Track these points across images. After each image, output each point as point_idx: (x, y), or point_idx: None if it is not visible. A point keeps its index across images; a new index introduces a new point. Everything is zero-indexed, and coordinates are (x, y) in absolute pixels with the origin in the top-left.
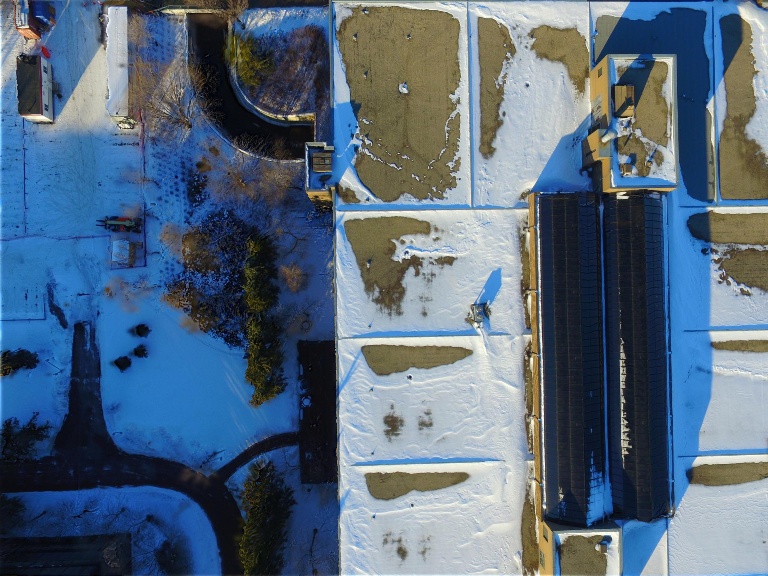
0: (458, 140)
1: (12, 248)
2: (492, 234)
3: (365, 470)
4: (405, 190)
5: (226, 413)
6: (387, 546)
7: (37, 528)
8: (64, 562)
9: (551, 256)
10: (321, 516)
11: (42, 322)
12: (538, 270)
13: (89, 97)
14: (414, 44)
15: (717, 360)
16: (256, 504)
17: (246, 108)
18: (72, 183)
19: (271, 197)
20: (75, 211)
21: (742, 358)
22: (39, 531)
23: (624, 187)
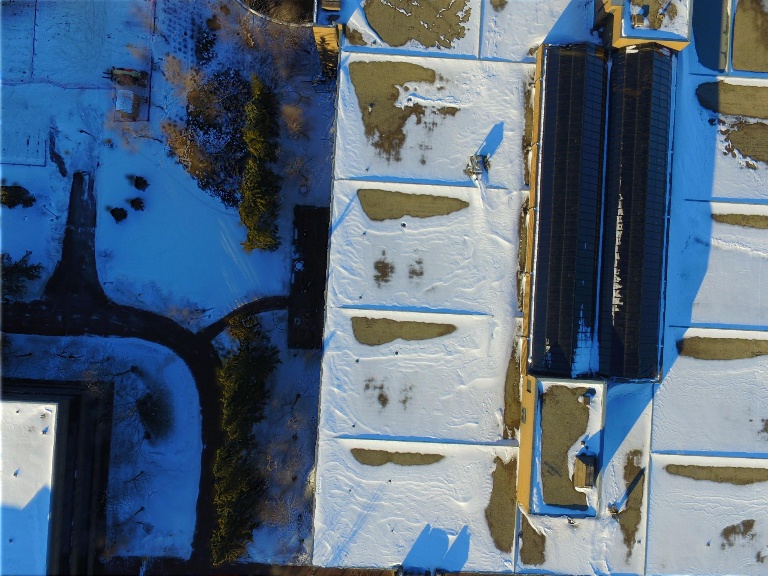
0: None
1: (18, 93)
2: (497, 87)
3: (352, 313)
4: (413, 36)
5: (218, 272)
6: (368, 392)
7: (22, 369)
8: (45, 392)
9: (555, 106)
10: (305, 381)
11: (42, 168)
12: (541, 123)
13: None
14: None
15: (716, 233)
16: (240, 342)
17: None
18: (82, 33)
19: (278, 59)
20: (83, 61)
21: (742, 233)
22: (23, 372)
23: (634, 37)
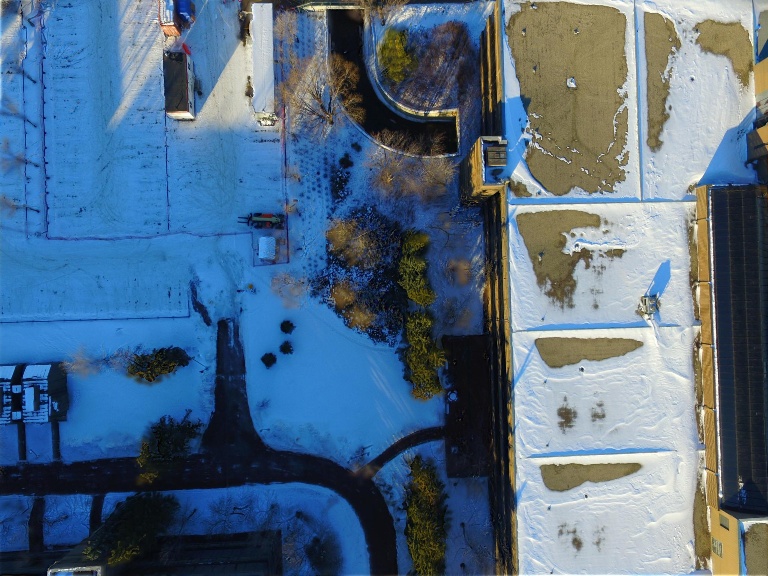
0: (626, 134)
1: (154, 246)
2: (661, 227)
3: (540, 462)
4: (575, 184)
5: (372, 408)
6: (562, 537)
7: (188, 526)
8: (231, 559)
9: (727, 247)
10: (468, 510)
11: (186, 319)
12: (711, 262)
13: (229, 94)
14: (581, 39)
15: None
16: (429, 498)
17: (386, 104)
18: (213, 180)
19: (414, 193)
20: (217, 208)
21: None
22: (190, 529)
23: None
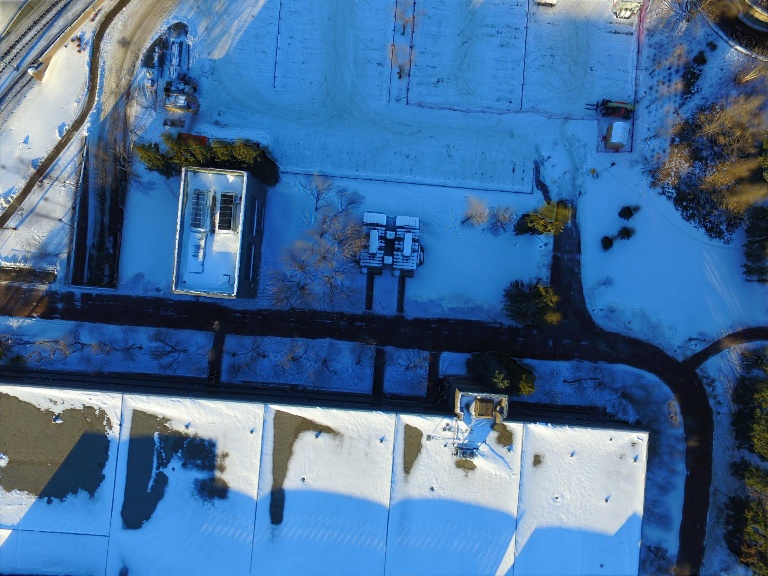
0: None
1: (504, 122)
2: None
3: None
4: None
5: (703, 301)
6: None
7: None
8: (591, 418)
9: None
10: None
11: (529, 196)
12: None
13: None
14: None
15: None
16: None
17: (740, 9)
18: (565, 65)
19: (764, 96)
20: (566, 93)
21: None
22: (521, 395)
23: None
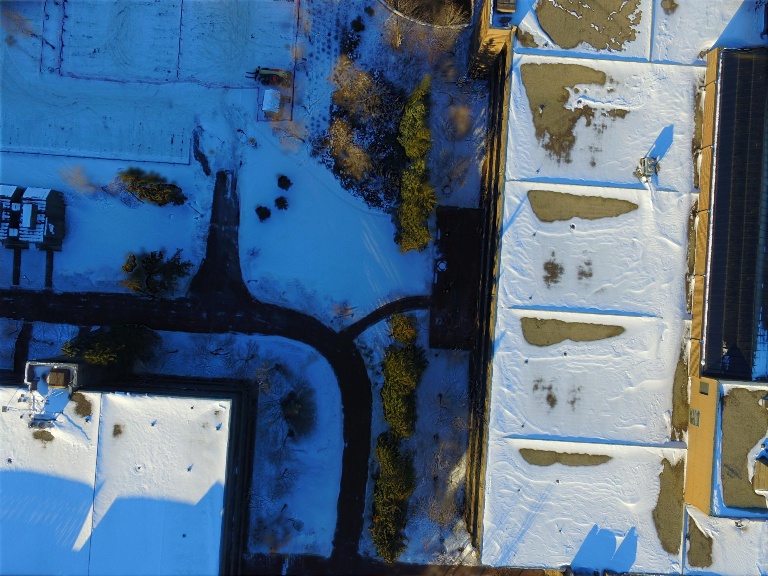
0: None
1: (162, 92)
2: (667, 90)
3: (522, 314)
4: (583, 39)
5: (361, 271)
6: (537, 392)
7: (168, 365)
8: (206, 388)
9: (733, 110)
10: (447, 381)
11: (186, 166)
12: (715, 126)
13: None
14: None
15: None
16: (407, 341)
17: None
18: (225, 33)
19: (422, 61)
20: (226, 61)
21: None
22: (170, 368)
23: None
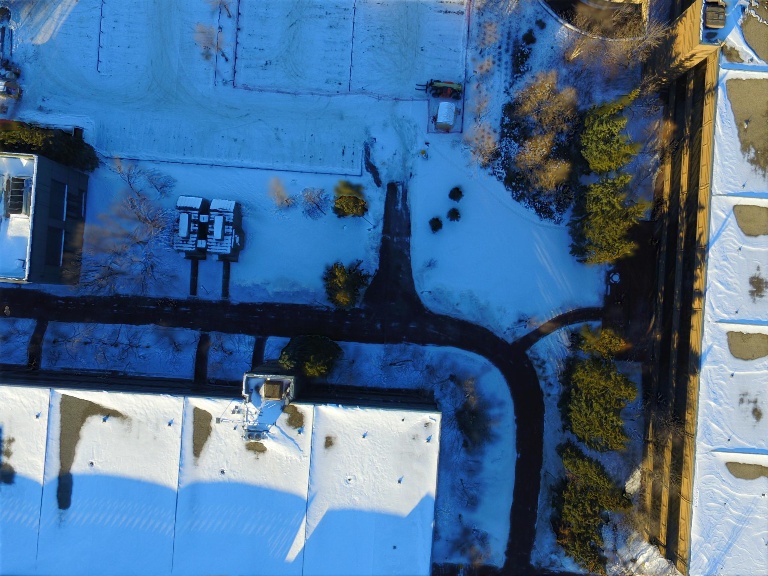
0: None
1: (333, 104)
2: None
3: (728, 328)
4: None
5: (533, 282)
6: (743, 406)
7: (345, 376)
8: (399, 400)
9: None
10: None
11: (358, 178)
12: None
13: None
14: None
15: None
16: (609, 354)
17: None
18: (395, 46)
19: (594, 73)
20: (396, 73)
21: None
22: (347, 379)
23: None
